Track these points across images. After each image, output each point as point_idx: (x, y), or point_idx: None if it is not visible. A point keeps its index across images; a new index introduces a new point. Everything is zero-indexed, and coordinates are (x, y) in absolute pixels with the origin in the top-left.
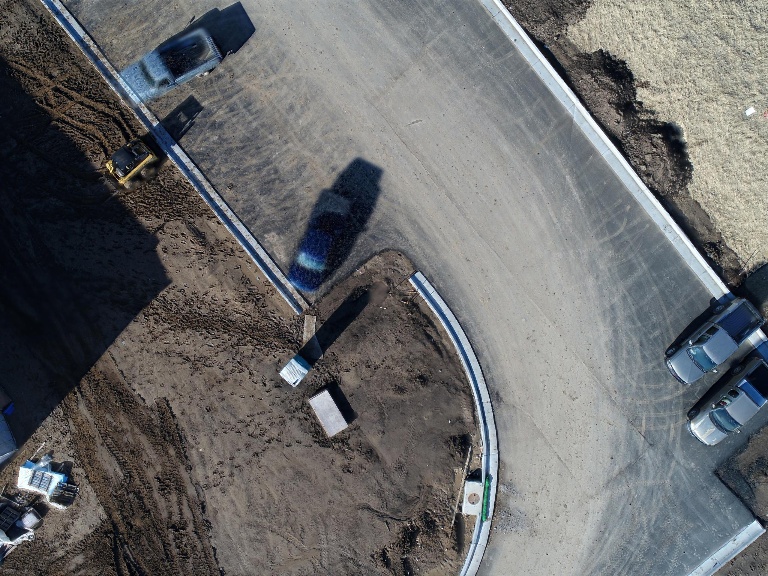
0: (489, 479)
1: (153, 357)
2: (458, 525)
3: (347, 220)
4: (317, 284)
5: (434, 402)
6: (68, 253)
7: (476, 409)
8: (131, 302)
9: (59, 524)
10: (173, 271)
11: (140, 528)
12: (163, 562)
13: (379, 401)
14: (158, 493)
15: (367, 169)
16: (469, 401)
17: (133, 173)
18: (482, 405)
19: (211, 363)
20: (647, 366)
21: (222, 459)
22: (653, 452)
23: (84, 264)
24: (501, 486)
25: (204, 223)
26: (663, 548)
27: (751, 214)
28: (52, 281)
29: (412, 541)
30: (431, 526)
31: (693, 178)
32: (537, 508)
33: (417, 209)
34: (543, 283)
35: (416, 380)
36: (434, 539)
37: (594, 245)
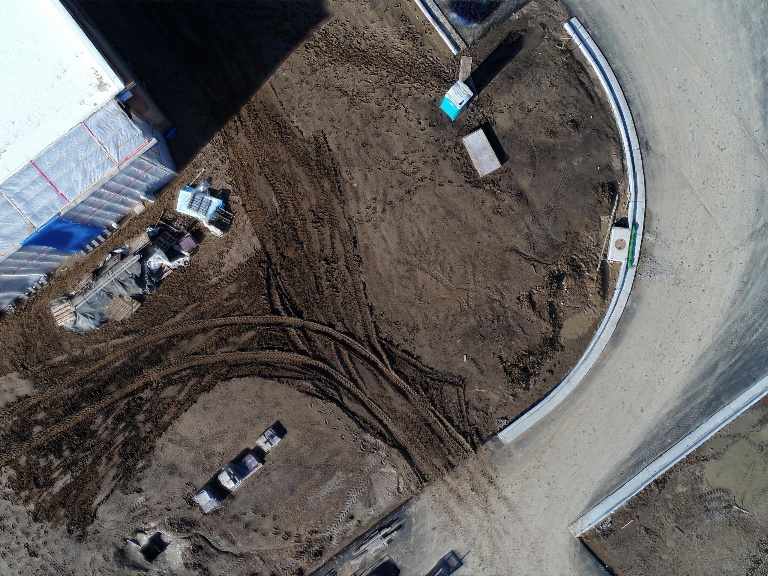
0: (635, 226)
1: (312, 90)
2: (603, 271)
3: None
4: (475, 25)
5: (584, 147)
6: None
7: (625, 157)
8: (293, 34)
9: (214, 252)
10: (335, 5)
11: (292, 260)
12: (314, 295)
13: (531, 144)
14: (312, 226)
15: None
16: (618, 148)
17: None
18: (632, 152)
19: (368, 99)
20: None
21: (375, 195)
22: None
23: None
24: (647, 234)
25: None
26: None
27: None
28: (218, 9)
29: (559, 282)
30: (577, 270)
31: None
32: (681, 257)
33: None
34: (696, 32)
35: (568, 124)
36: (579, 284)
37: None
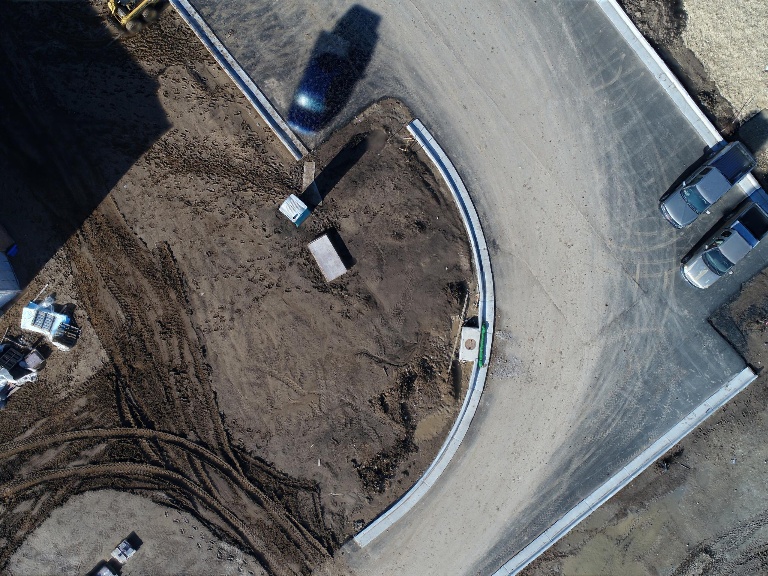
0: (485, 325)
1: (154, 201)
2: (455, 371)
3: (346, 67)
4: (316, 130)
5: (431, 249)
6: (70, 96)
7: (473, 256)
8: (133, 146)
9: (62, 366)
10: (174, 116)
11: (142, 371)
12: (164, 405)
13: (377, 247)
14: (159, 336)
15: (366, 17)
16: (466, 248)
17: (135, 12)
18: (479, 252)
19: (212, 208)
20: (641, 214)
21: (222, 303)
22: (647, 299)
23: (86, 107)
24: (497, 333)
25: (205, 69)
26: (656, 394)
27: (744, 61)
28: (55, 124)
29: (409, 385)
30: (428, 371)
31: (687, 27)
32: (533, 354)
33: (415, 57)
34: (539, 131)
35: (414, 226)
36: (431, 384)
37: (590, 93)
